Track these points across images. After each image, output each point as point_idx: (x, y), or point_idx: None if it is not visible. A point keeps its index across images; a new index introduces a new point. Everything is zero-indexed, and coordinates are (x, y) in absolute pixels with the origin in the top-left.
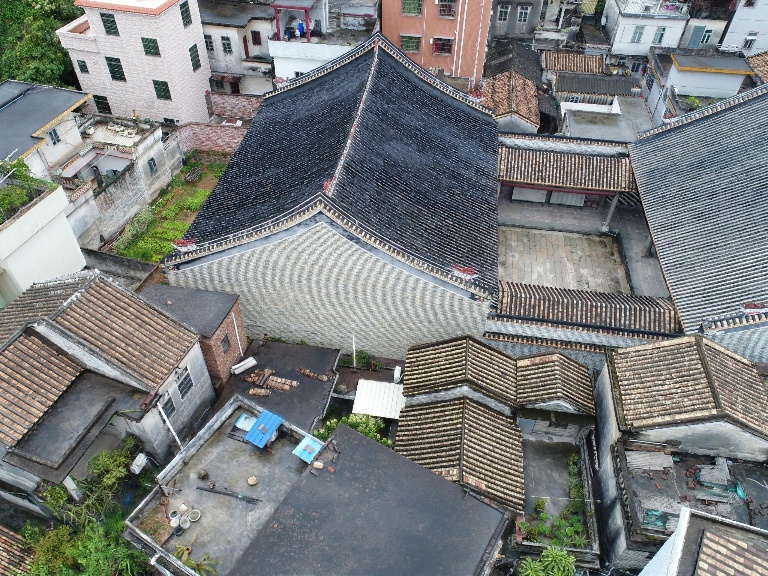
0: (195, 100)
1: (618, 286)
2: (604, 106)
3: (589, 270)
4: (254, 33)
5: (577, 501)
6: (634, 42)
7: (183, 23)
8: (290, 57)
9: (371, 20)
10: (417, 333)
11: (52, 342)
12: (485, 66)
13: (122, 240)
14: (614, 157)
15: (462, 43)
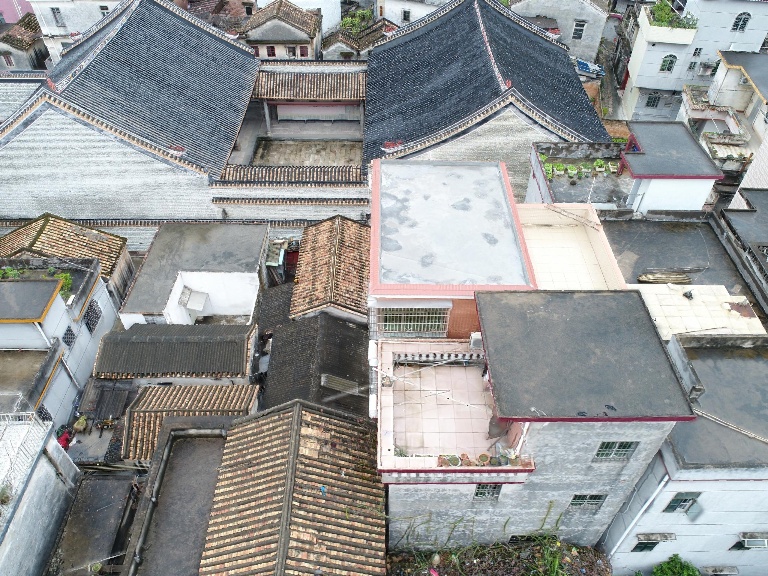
0: None
1: None
2: None
3: None
4: None
5: None
6: None
7: None
8: None
9: None
10: None
11: None
12: None
13: None
14: None
15: None
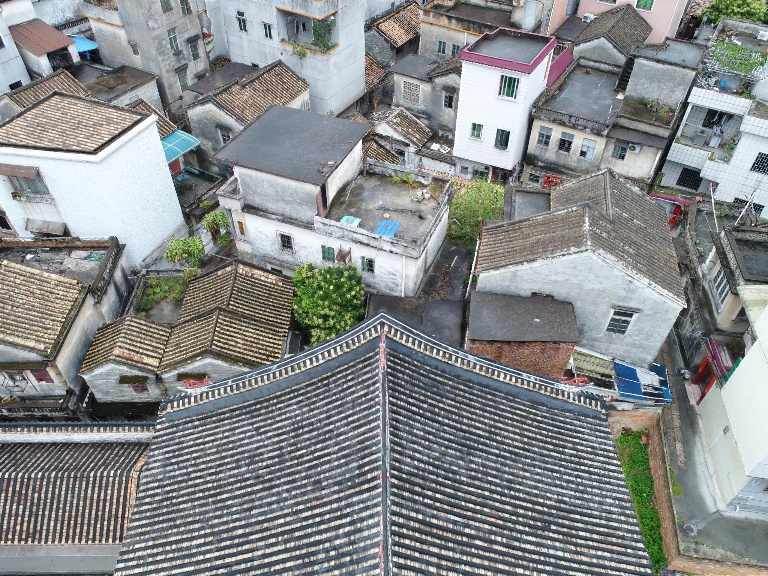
0: None
1: None
2: None
3: None
4: None
5: (143, 303)
6: None
7: None
8: None
9: None
10: None
11: None
12: None
13: None
14: None
15: None
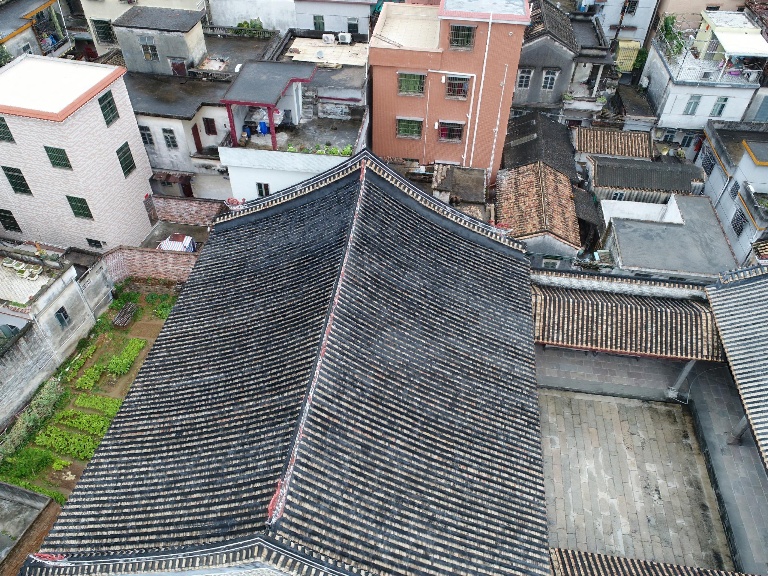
0: (129, 211)
1: (700, 495)
2: (657, 205)
3: (657, 466)
4: (206, 121)
5: None
6: (687, 114)
7: (105, 120)
8: (249, 167)
9: (358, 108)
10: None
11: None
12: (503, 147)
13: (11, 440)
14: (686, 302)
15: (476, 128)
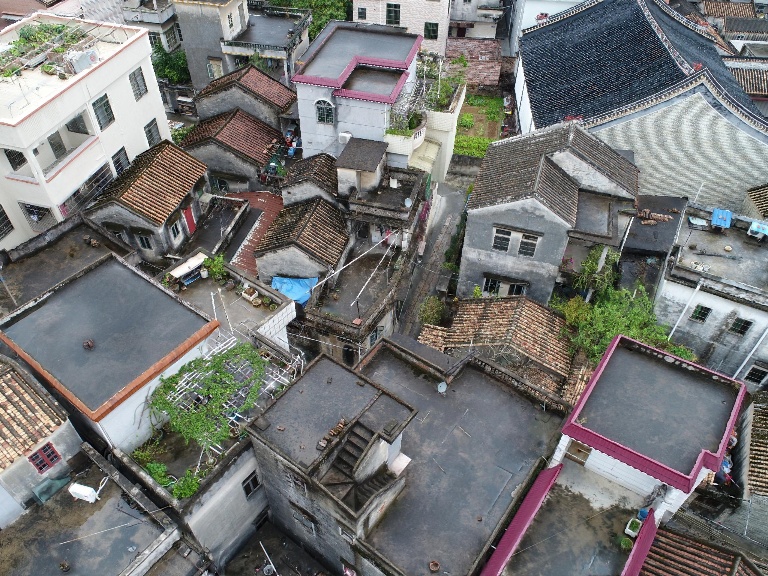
0: (444, 42)
1: None
2: (766, 42)
3: None
4: None
5: None
6: None
7: None
8: None
9: None
10: (728, 190)
11: (560, 168)
12: None
13: None
14: None
15: None
